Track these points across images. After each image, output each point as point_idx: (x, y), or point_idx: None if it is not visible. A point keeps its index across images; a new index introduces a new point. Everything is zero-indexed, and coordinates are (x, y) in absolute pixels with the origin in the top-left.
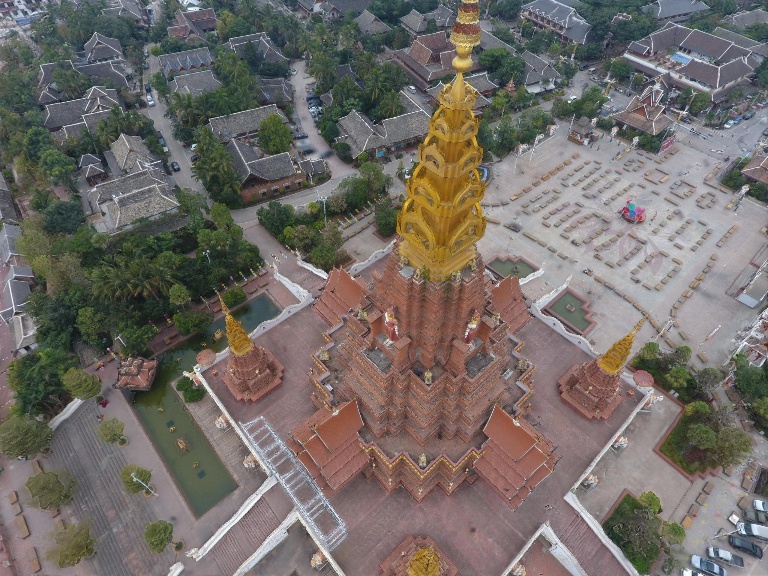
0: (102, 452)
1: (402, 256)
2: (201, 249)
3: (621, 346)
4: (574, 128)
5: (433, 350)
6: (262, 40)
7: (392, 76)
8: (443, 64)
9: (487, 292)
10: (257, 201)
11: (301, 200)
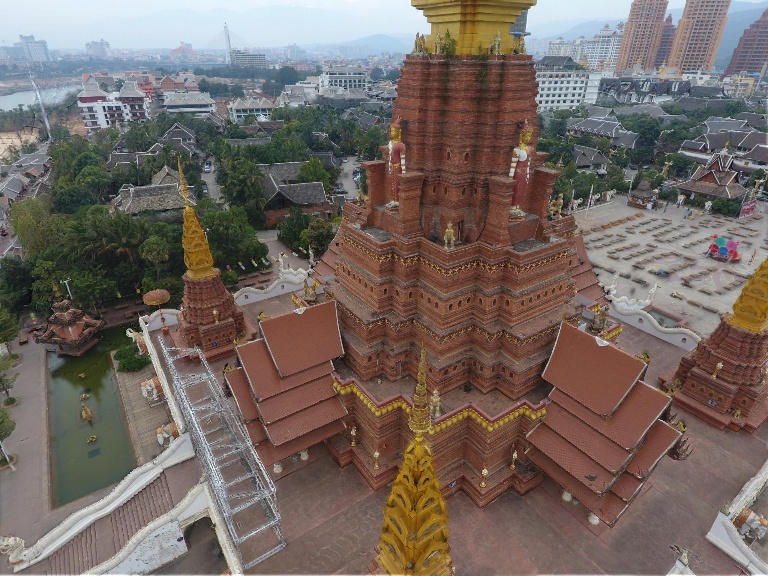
0: None
1: None
2: None
3: (766, 270)
4: (634, 193)
5: (458, 201)
6: (320, 134)
7: None
8: None
9: None
10: None
11: None
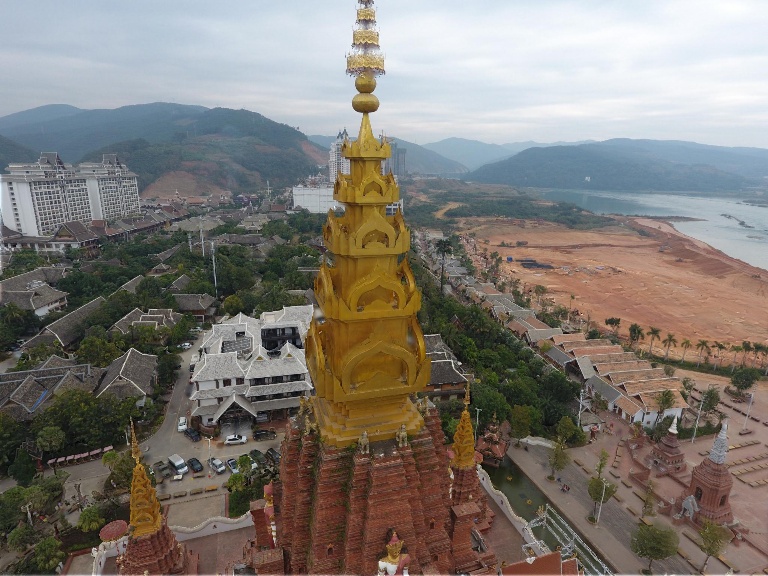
0: None
1: None
2: None
3: None
4: None
5: None
6: None
7: None
8: None
9: (234, 569)
10: None
11: None
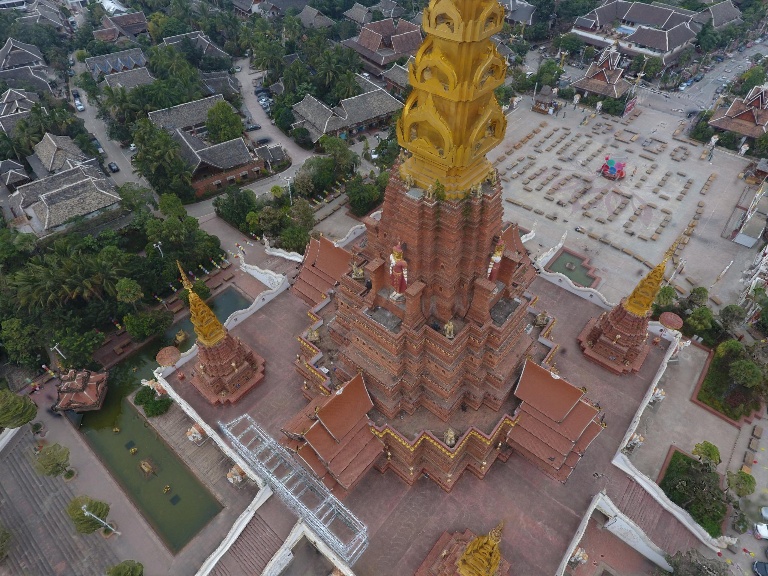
0: (43, 491)
1: (407, 174)
2: (151, 245)
3: (651, 279)
4: (537, 98)
5: (451, 296)
6: (200, 37)
7: (345, 58)
8: (395, 48)
9: None
10: (212, 194)
11: (261, 189)
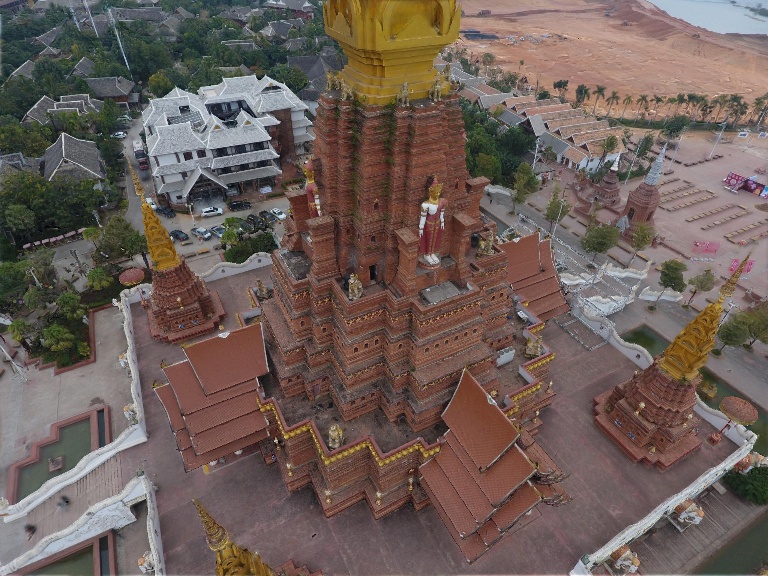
0: None
1: None
2: None
3: None
4: None
5: None
6: None
7: None
8: None
9: (279, 253)
10: None
11: None
